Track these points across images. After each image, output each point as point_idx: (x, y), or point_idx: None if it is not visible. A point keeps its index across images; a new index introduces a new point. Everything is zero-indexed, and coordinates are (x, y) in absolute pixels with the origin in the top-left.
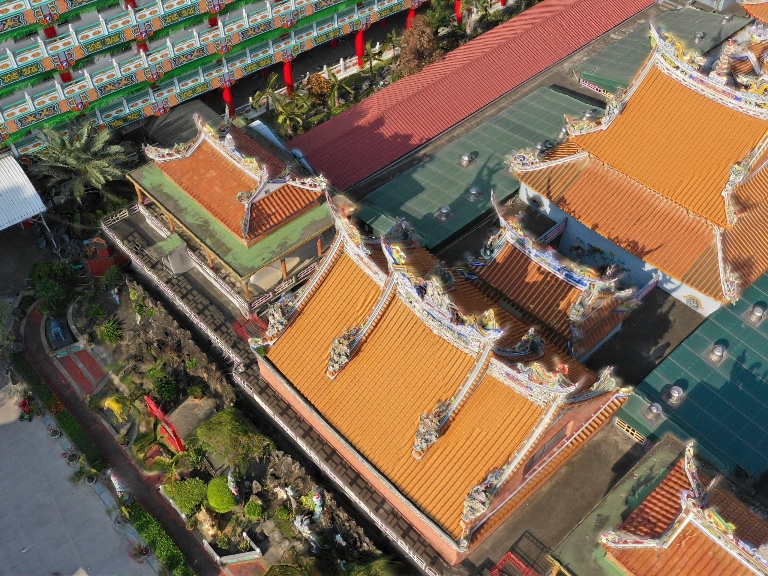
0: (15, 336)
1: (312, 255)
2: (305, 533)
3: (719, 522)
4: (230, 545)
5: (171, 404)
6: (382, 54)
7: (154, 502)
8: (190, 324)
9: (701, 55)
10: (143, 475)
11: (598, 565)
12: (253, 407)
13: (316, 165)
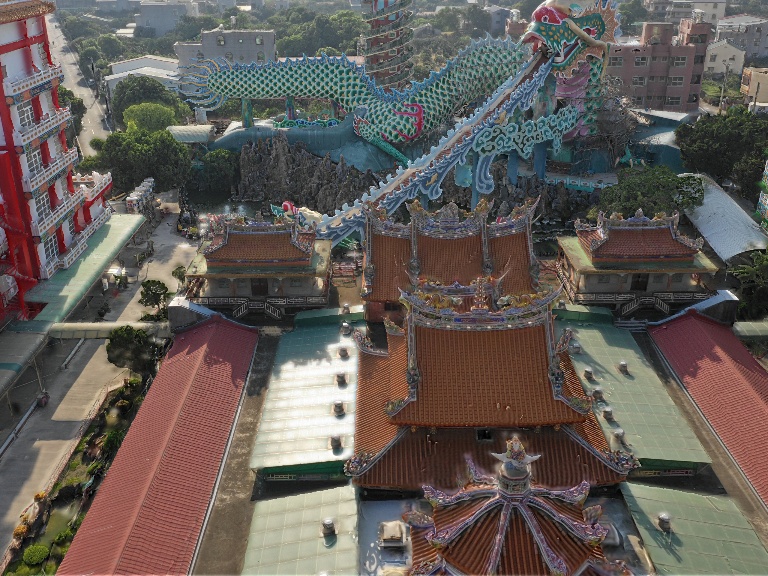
0: None
1: None
2: None
3: None
4: None
5: None
6: None
7: None
8: None
9: (658, 571)
10: None
11: None
12: None
13: None
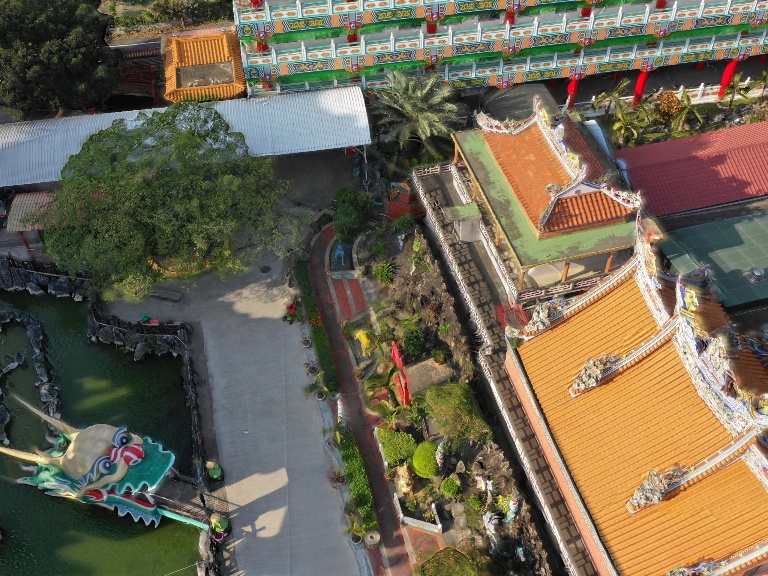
0: (305, 245)
1: (598, 269)
2: (489, 531)
3: None
4: (417, 509)
5: (413, 358)
6: (749, 91)
7: (365, 439)
8: (457, 292)
9: None
10: (365, 411)
11: None
12: (485, 392)
13: (636, 182)
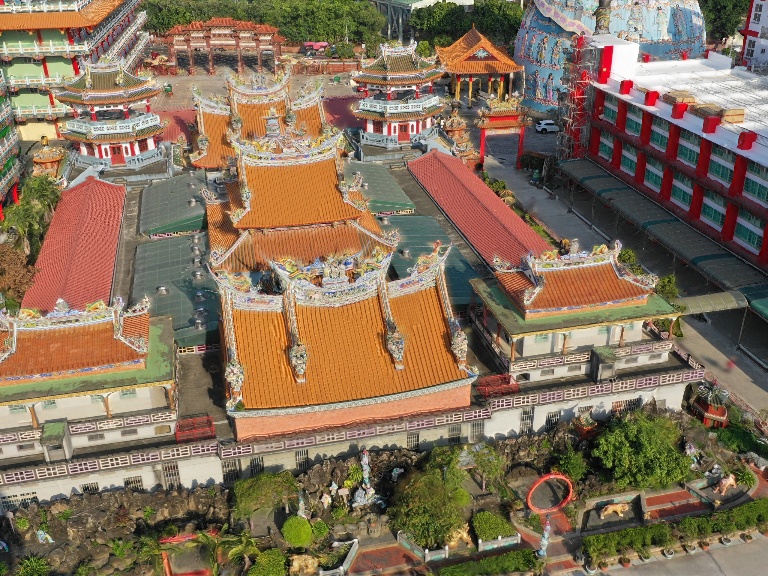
0: None
1: None
2: (371, 498)
3: (551, 253)
4: (337, 557)
5: None
6: None
7: None
8: (115, 489)
9: None
10: None
11: (528, 324)
12: None
13: None
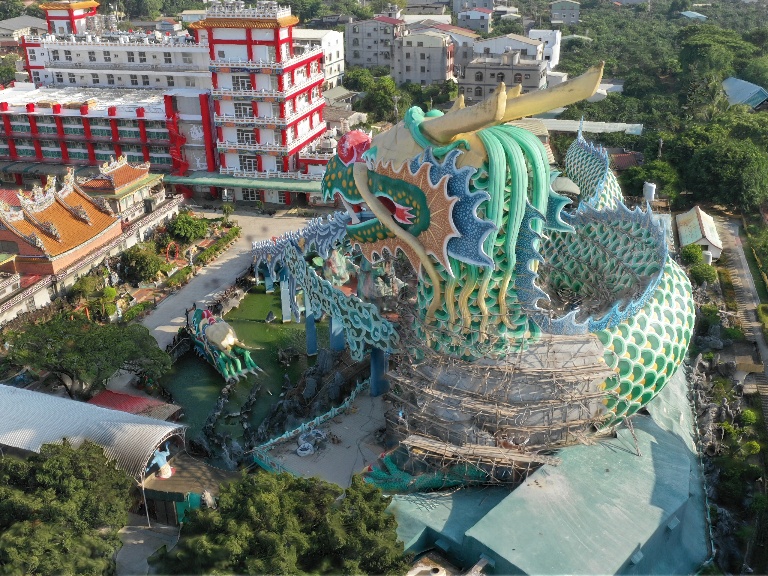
0: None
1: None
2: None
3: None
4: None
5: None
6: None
7: None
8: None
9: None
10: None
11: None
12: None
13: None
